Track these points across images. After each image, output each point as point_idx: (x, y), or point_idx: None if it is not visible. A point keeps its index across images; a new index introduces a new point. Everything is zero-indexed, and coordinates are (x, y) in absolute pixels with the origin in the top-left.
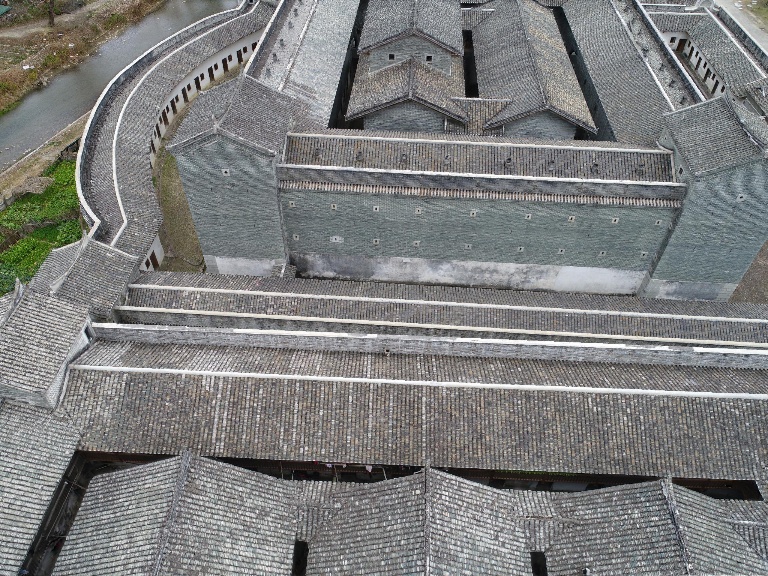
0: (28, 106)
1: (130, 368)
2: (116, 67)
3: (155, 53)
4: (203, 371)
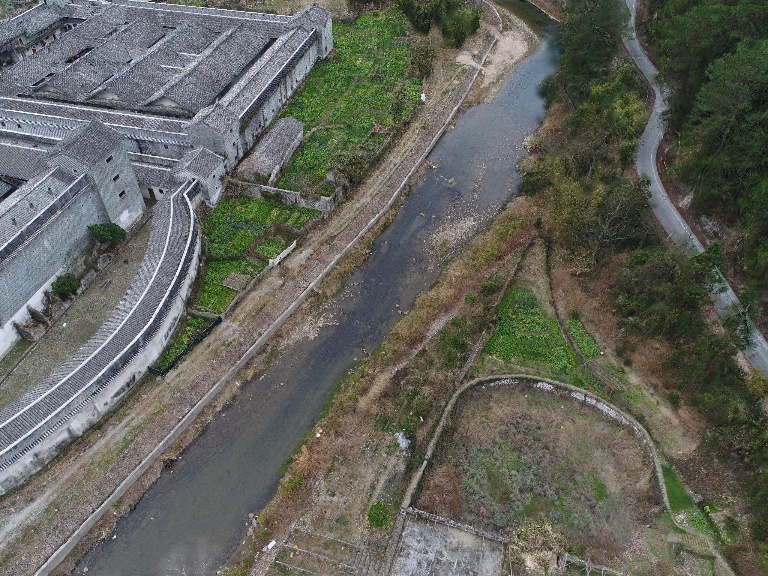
0: (270, 467)
1: (178, 121)
2: (153, 562)
3: (92, 387)
4: (154, 118)
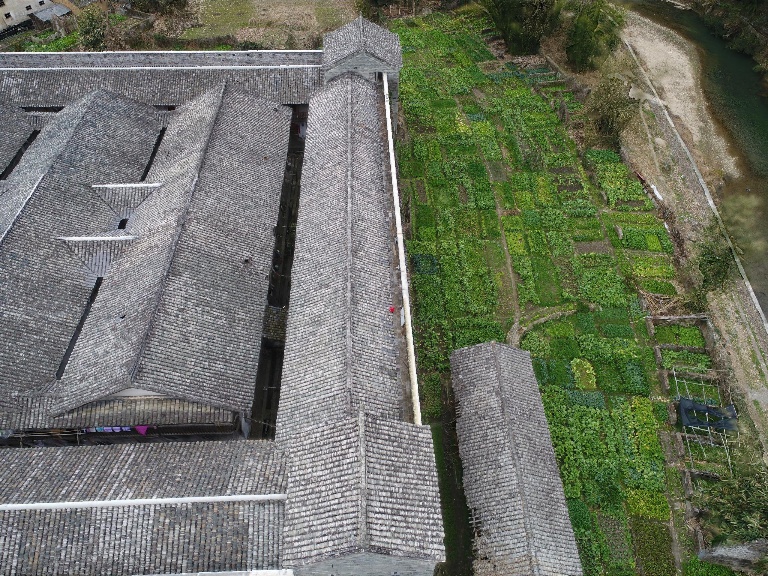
0: None
1: (220, 497)
2: None
3: None
4: (128, 502)
